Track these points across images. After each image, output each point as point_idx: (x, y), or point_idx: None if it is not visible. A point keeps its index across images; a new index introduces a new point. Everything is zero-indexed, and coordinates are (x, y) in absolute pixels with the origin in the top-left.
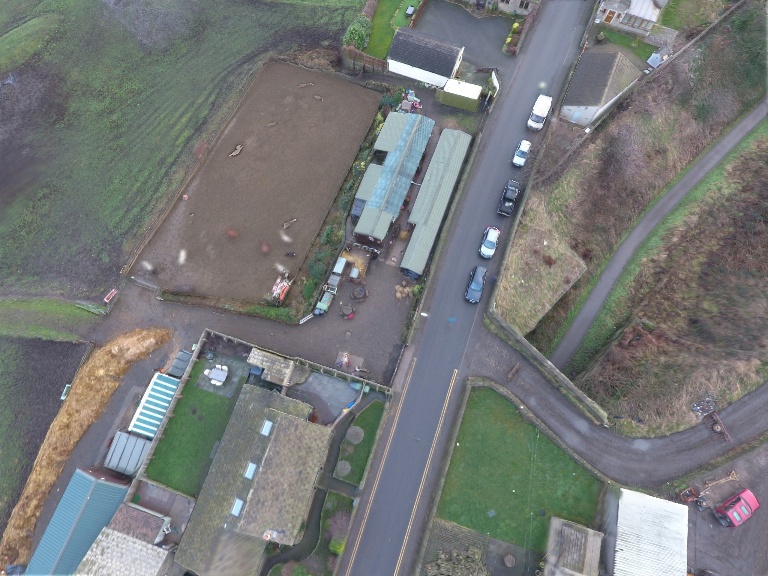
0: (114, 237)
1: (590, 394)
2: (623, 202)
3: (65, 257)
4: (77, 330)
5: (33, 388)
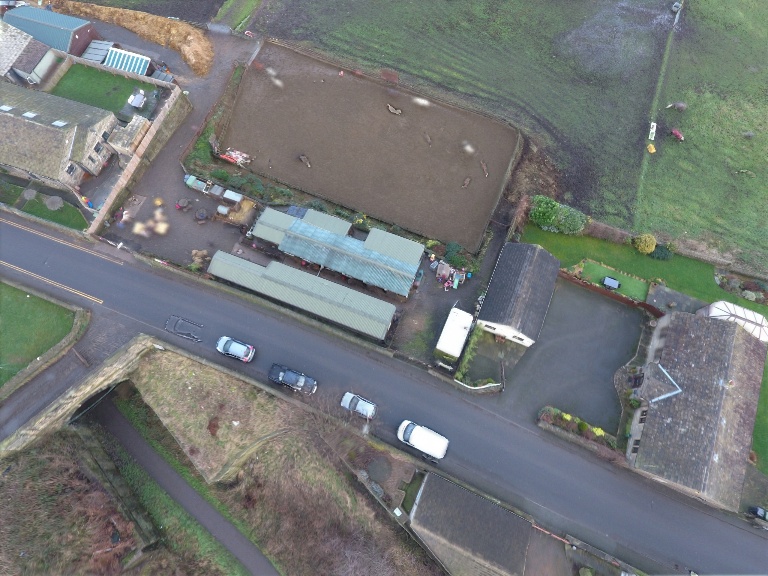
0: (319, 35)
1: (54, 452)
2: (313, 567)
3: (306, 8)
4: (225, 19)
5: (186, 2)
